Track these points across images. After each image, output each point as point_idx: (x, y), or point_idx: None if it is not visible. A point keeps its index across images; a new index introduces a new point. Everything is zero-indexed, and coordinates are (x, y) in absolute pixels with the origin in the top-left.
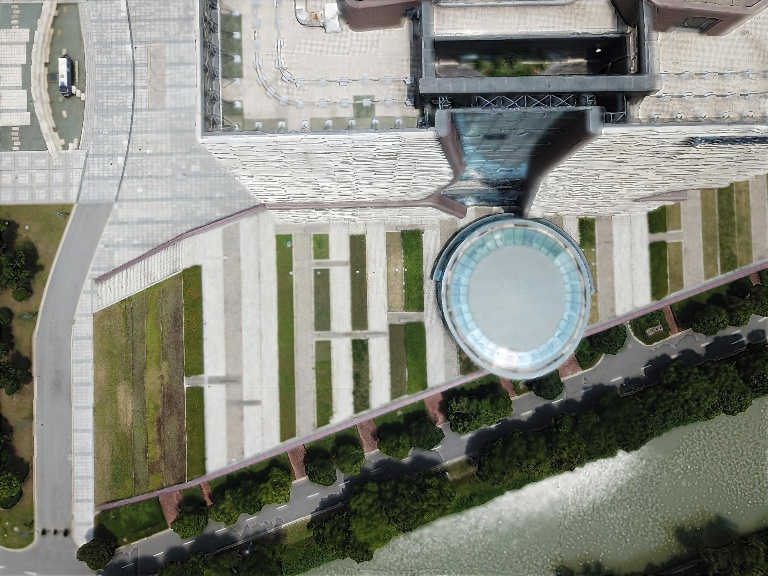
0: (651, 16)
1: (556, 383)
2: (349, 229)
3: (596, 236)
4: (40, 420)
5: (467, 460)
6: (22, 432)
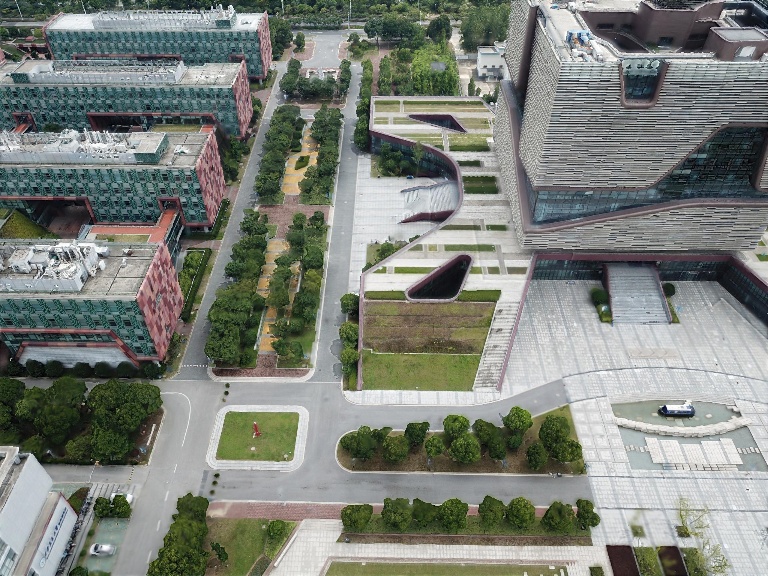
0: None
1: None
2: None
3: None
4: None
5: None
6: None
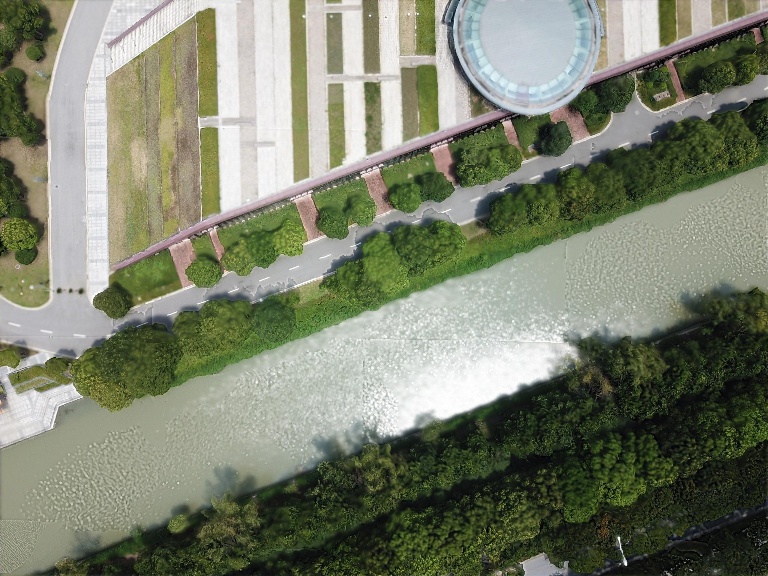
0: None
1: (565, 132)
2: None
3: None
4: (54, 182)
5: (477, 223)
6: (37, 193)
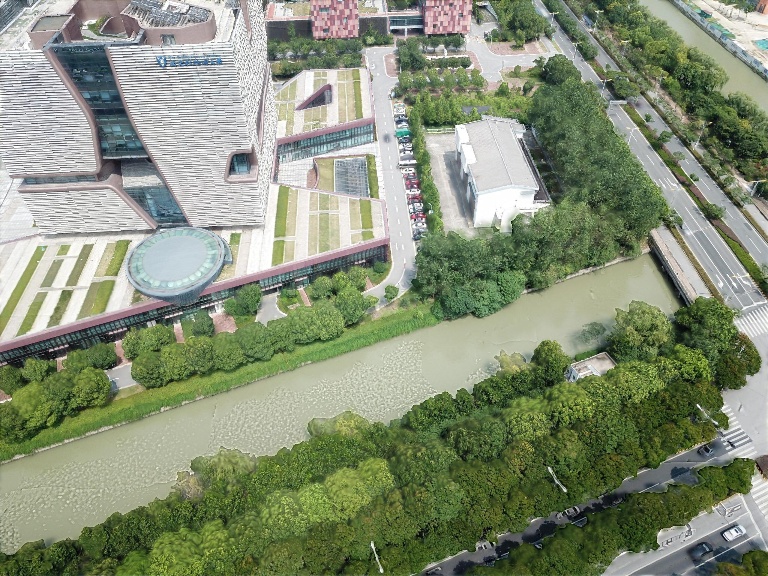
0: None
1: None
2: (85, 242)
3: (240, 240)
4: None
5: (136, 386)
6: None
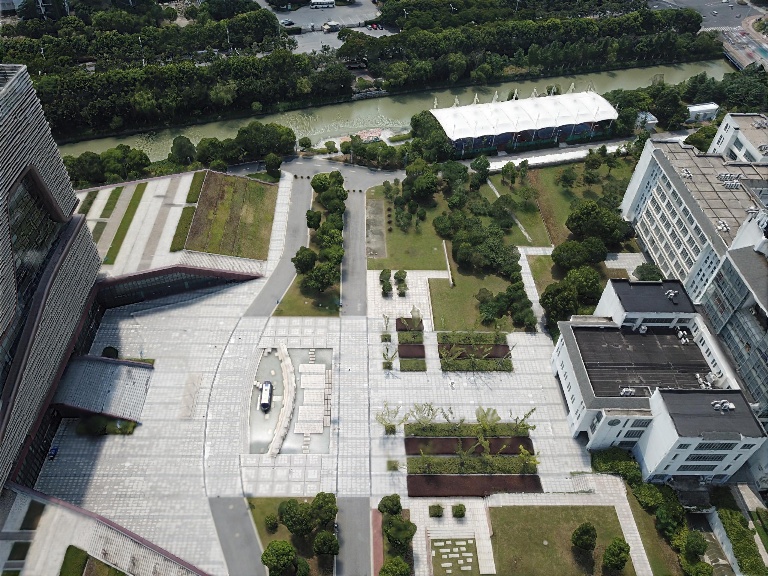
0: None
1: None
2: None
3: None
4: None
5: None
6: None
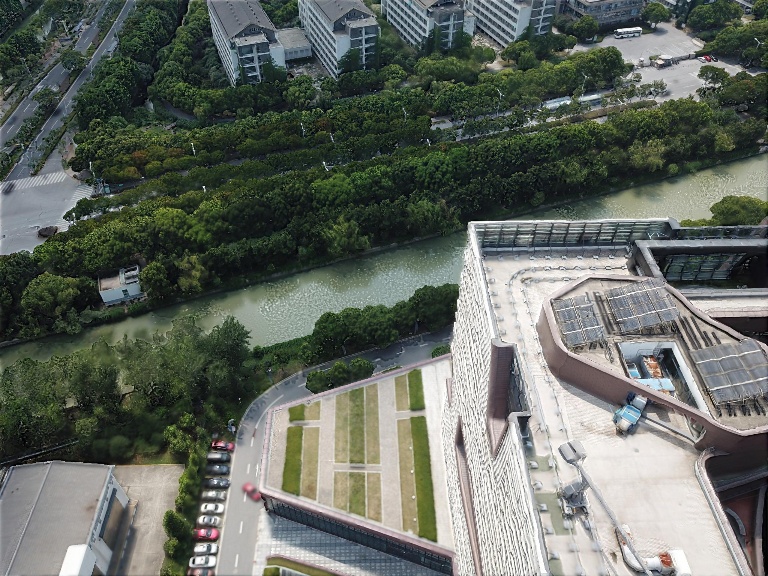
0: (658, 275)
1: None
2: None
3: None
4: None
5: None
6: None
